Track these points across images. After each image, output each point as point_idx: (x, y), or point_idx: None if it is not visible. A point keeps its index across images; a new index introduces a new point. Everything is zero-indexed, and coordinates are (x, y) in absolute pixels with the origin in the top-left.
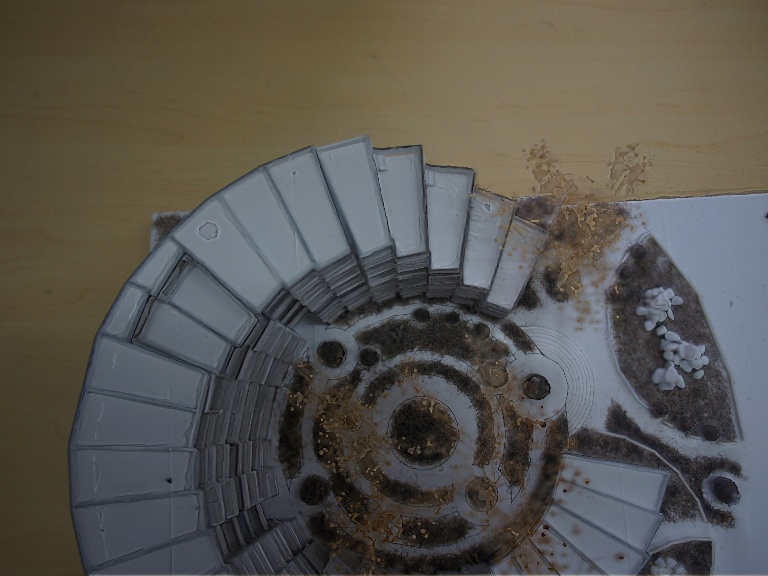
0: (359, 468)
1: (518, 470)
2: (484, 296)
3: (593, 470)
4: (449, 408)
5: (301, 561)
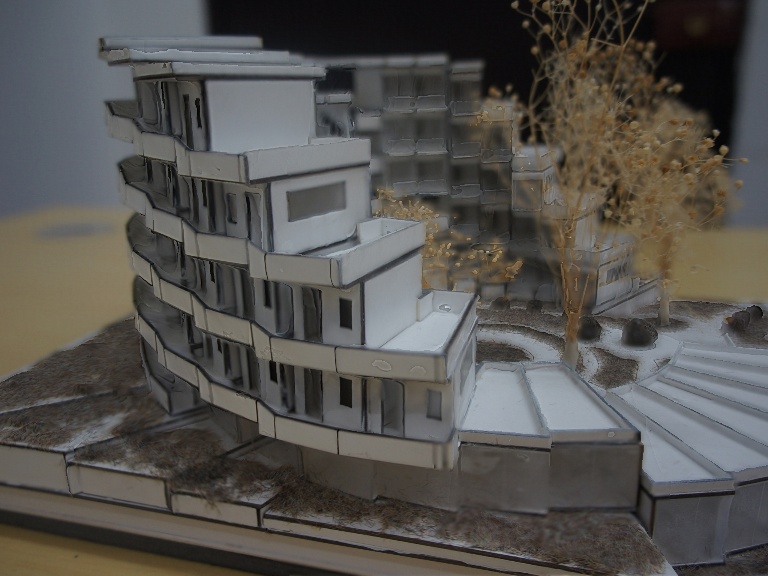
0: None
1: (617, 380)
2: (570, 248)
3: (729, 358)
4: (523, 349)
5: None
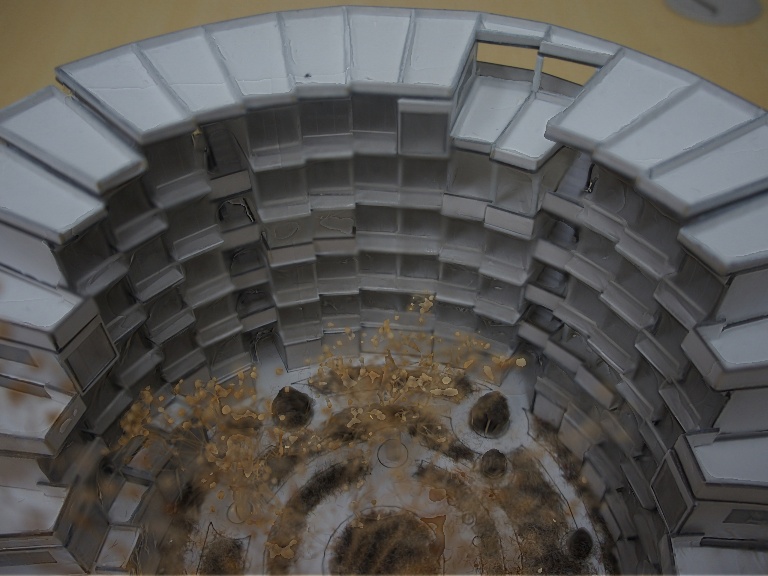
0: (325, 469)
1: None
2: None
3: None
4: None
5: (195, 356)
